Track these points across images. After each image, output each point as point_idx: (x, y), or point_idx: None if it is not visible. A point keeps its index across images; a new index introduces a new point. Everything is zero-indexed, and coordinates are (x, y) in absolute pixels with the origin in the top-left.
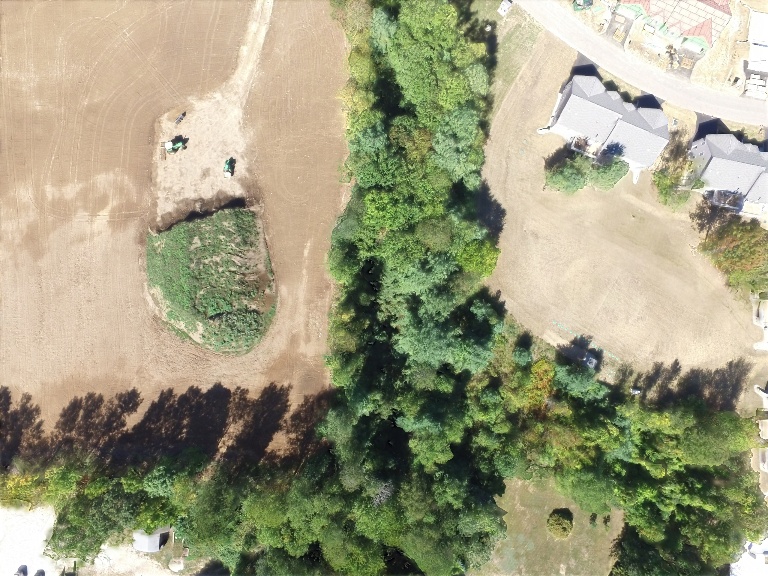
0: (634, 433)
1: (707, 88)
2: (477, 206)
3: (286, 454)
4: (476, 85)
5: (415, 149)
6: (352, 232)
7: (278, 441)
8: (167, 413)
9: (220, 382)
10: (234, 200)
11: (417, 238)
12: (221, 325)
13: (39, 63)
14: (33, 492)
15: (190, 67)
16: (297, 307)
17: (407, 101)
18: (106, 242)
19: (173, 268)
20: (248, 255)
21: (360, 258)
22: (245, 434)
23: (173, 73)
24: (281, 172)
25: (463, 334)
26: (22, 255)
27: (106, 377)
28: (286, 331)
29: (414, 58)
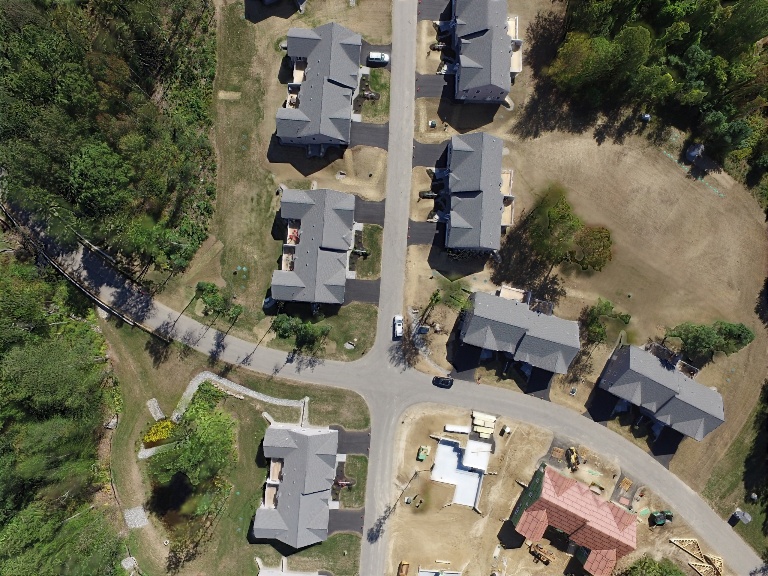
0: None
1: (536, 426)
2: None
3: None
4: None
5: None
6: None
7: None
8: None
9: None
10: None
11: None
12: None
13: None
14: None
15: None
16: None
17: None
18: None
19: None
20: None
21: None
22: None
23: None
24: None
25: None
26: None
27: None
28: None
29: None
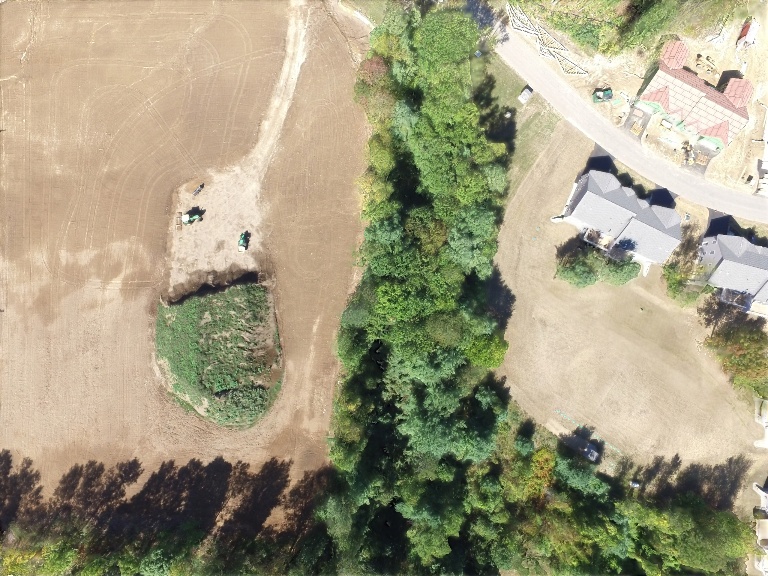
0: (631, 527)
1: (721, 185)
2: (487, 291)
3: (283, 529)
4: (494, 184)
5: (430, 242)
6: (363, 320)
7: (276, 516)
8: (167, 485)
9: (222, 456)
10: (247, 274)
11: (427, 332)
12: (227, 402)
13: (62, 127)
14: (29, 569)
15: (211, 139)
16: (303, 382)
17: (424, 187)
18: (117, 310)
19: (182, 343)
20: (257, 330)
21: (369, 341)
22: (243, 508)
23: (194, 144)
24: (295, 247)
25: (467, 423)
26: (32, 319)
27: (108, 446)
28: (290, 406)
29: (434, 151)
